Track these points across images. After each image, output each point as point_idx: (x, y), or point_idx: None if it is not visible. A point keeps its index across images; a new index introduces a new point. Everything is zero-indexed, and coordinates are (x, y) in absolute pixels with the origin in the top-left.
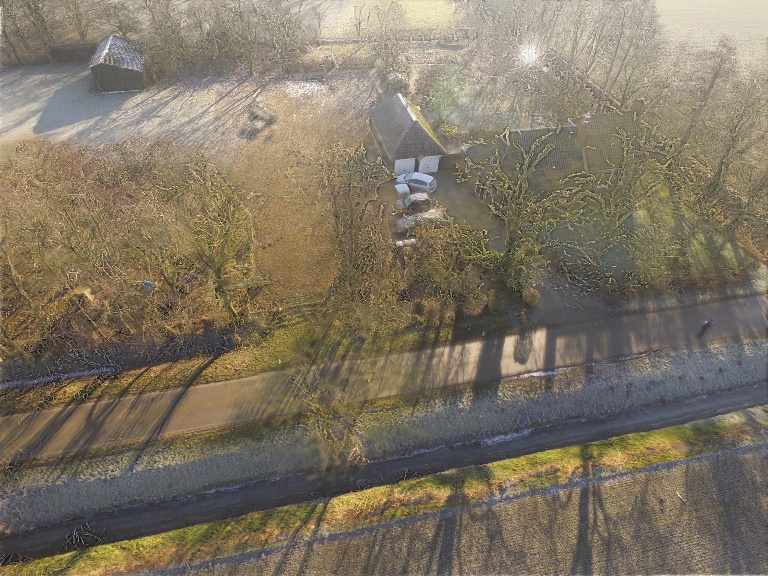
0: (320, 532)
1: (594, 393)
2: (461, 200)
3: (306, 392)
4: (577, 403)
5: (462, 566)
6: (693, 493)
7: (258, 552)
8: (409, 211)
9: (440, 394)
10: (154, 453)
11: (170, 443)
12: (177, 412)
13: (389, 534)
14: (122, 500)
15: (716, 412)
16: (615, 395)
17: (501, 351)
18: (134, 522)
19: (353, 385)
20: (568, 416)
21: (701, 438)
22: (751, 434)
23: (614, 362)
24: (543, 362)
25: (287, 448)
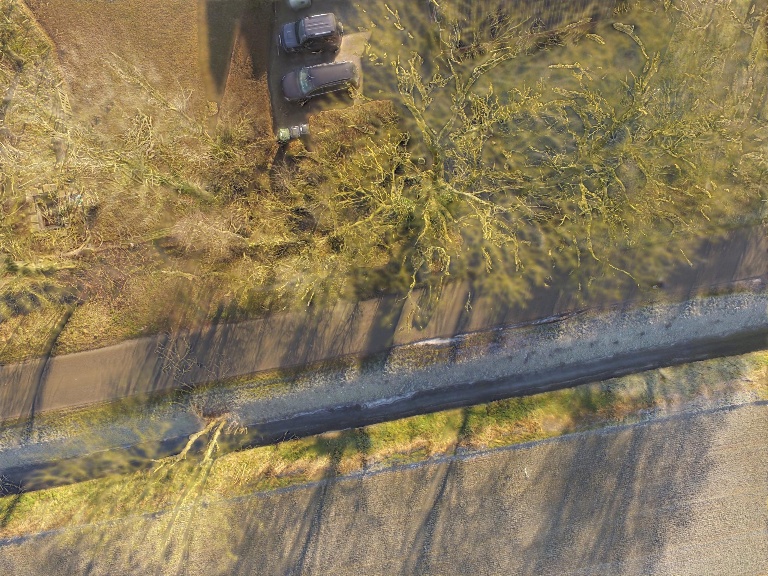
0: (202, 500)
1: (489, 363)
2: (398, 10)
3: (176, 366)
4: (468, 372)
5: (320, 525)
6: (539, 470)
7: (152, 514)
8: (306, 49)
9: (321, 368)
10: (36, 429)
11: (48, 420)
12: (44, 388)
13: (262, 501)
14: (25, 463)
15: (613, 374)
16: (512, 363)
17: (399, 312)
18: (44, 475)
19: (227, 357)
20: (455, 382)
21: (576, 414)
22: (626, 416)
23: (525, 327)
24: (444, 327)
25: (166, 422)
